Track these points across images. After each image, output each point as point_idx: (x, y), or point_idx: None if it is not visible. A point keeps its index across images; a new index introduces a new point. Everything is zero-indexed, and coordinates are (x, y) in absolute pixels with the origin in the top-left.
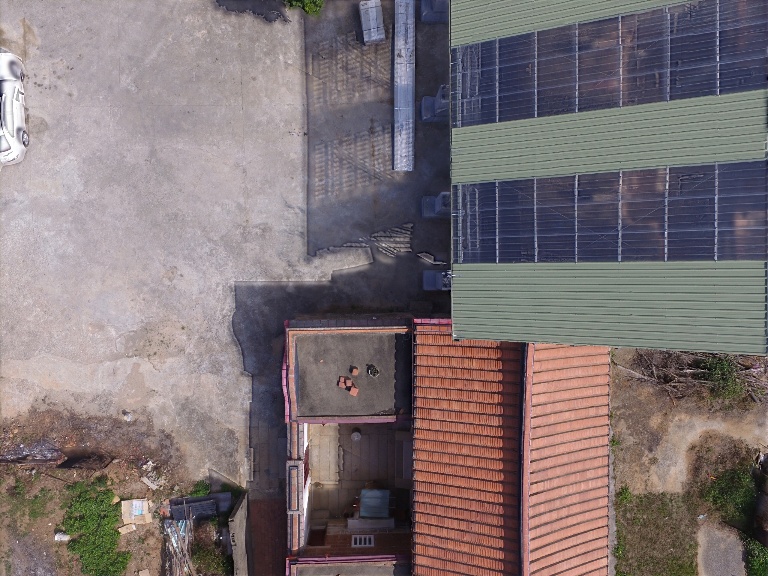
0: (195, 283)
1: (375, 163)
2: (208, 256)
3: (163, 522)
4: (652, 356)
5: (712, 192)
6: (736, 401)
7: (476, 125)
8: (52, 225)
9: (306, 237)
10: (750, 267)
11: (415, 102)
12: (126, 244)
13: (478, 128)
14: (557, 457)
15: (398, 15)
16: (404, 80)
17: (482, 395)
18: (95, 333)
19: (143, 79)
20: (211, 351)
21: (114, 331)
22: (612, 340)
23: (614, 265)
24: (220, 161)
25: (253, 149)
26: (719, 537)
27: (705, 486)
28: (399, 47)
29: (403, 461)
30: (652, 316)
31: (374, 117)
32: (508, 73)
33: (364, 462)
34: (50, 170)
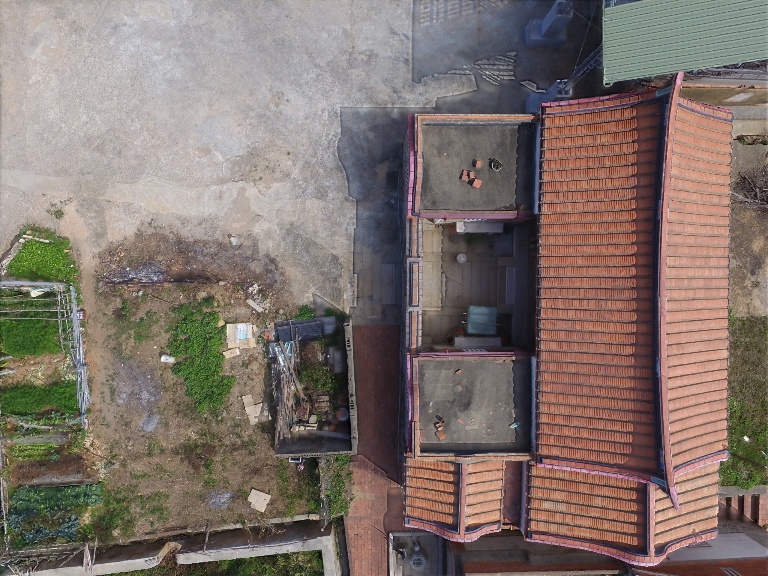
0: (301, 108)
1: None
2: (314, 82)
3: (267, 346)
4: (755, 179)
5: None
6: None
7: None
8: (161, 49)
9: (411, 64)
10: None
11: None
12: (233, 69)
13: None
14: (686, 236)
15: None
16: None
17: (615, 169)
18: (202, 157)
19: None
20: (316, 176)
21: (220, 155)
22: None
23: None
24: None
25: None
26: None
27: None
28: None
29: (506, 287)
30: None
31: None
32: None
33: (466, 289)
34: None
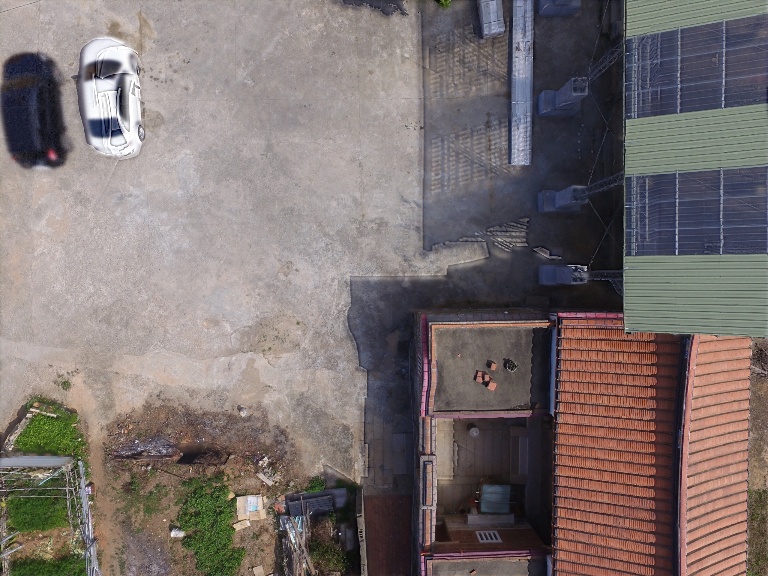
0: (310, 278)
1: (491, 157)
2: (324, 251)
3: (278, 518)
4: None
5: None
6: None
7: (654, 116)
8: (167, 220)
9: (422, 232)
10: None
11: (533, 96)
12: (241, 239)
13: (656, 119)
14: (705, 451)
15: (516, 8)
16: (522, 73)
17: (633, 389)
18: (210, 328)
19: (259, 73)
20: (326, 346)
21: (229, 326)
22: None
23: None
24: (336, 155)
25: (369, 143)
26: None
27: None
28: (517, 40)
29: (519, 457)
30: None
31: (491, 111)
32: (692, 63)
33: (479, 458)
34: (166, 164)
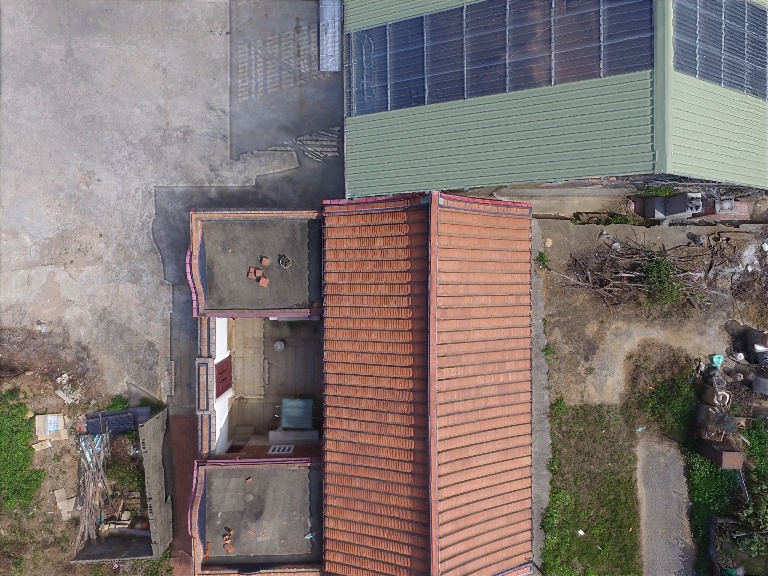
0: (113, 188)
1: (300, 64)
2: (127, 160)
3: (79, 438)
4: (587, 261)
5: (597, 4)
6: (675, 308)
7: None
8: None
9: (229, 140)
10: (635, 80)
11: None
12: (41, 147)
13: None
14: (472, 343)
15: None
16: None
17: (391, 275)
18: (9, 240)
19: None
20: (130, 259)
21: (28, 238)
22: (501, 177)
23: (502, 97)
24: (139, 61)
25: (173, 49)
26: (659, 451)
27: (643, 397)
28: None
29: None
30: (540, 146)
31: (299, 16)
32: None
33: (290, 376)
34: None
